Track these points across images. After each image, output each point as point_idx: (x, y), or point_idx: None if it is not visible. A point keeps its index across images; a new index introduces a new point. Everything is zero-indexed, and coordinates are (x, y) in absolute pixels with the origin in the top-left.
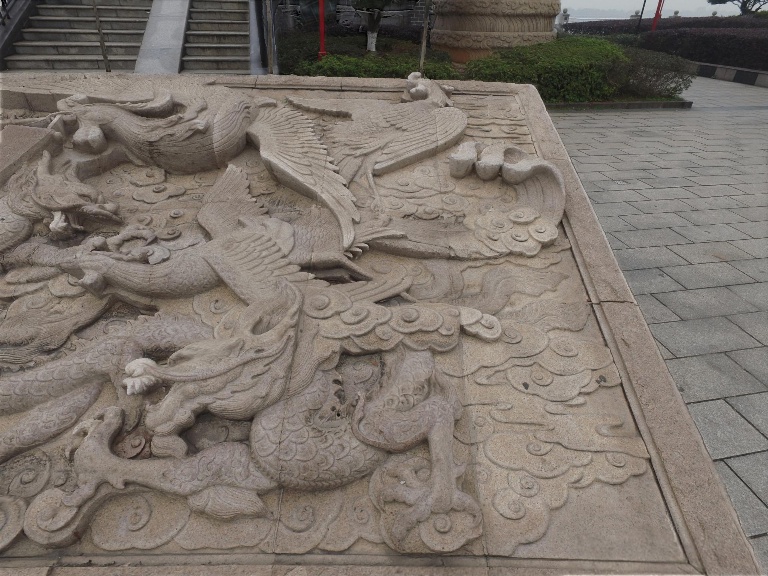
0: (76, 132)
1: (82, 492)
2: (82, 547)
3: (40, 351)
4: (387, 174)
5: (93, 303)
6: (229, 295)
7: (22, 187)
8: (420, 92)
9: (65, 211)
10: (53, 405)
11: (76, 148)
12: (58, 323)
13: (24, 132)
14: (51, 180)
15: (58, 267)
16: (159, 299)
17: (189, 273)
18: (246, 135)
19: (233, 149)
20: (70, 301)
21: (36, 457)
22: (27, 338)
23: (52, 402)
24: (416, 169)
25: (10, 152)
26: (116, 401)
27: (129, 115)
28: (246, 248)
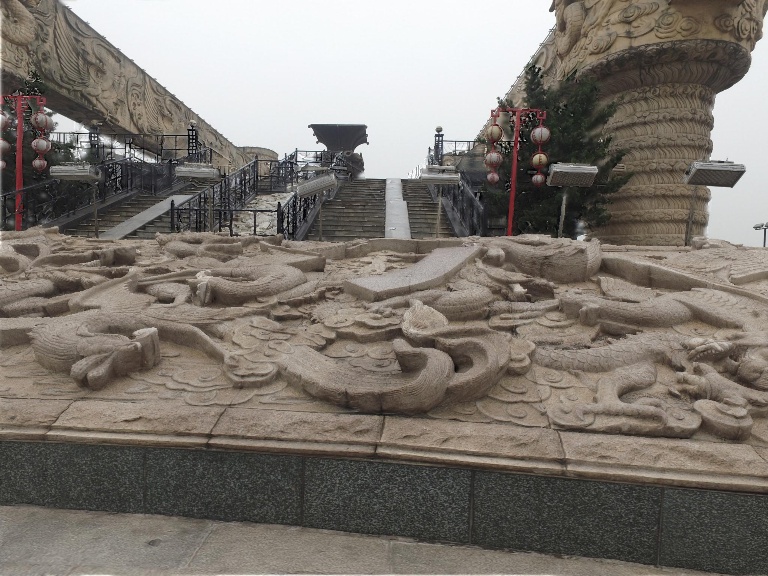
0: (488, 251)
1: (740, 398)
2: (755, 443)
3: (578, 346)
4: (739, 285)
5: (586, 329)
6: (704, 326)
7: (475, 274)
8: (714, 246)
9: (520, 284)
10: (632, 367)
11: (486, 262)
12: (571, 336)
13: (456, 249)
14: (495, 270)
15: (560, 301)
16: (643, 327)
17: (670, 307)
18: (601, 260)
19: (596, 268)
20: (561, 329)
21: (645, 395)
22: (559, 340)
23: (628, 366)
24: (760, 284)
25: (452, 258)
26: (675, 373)
27: (519, 244)
28: (703, 296)
